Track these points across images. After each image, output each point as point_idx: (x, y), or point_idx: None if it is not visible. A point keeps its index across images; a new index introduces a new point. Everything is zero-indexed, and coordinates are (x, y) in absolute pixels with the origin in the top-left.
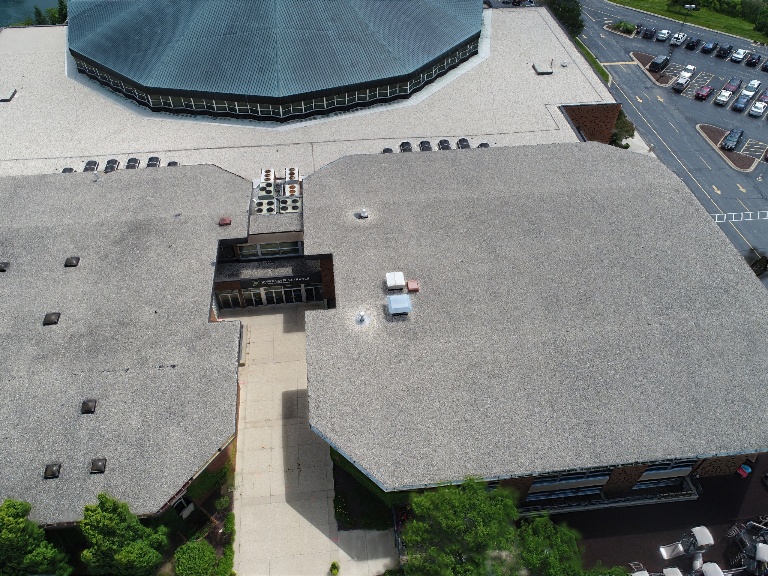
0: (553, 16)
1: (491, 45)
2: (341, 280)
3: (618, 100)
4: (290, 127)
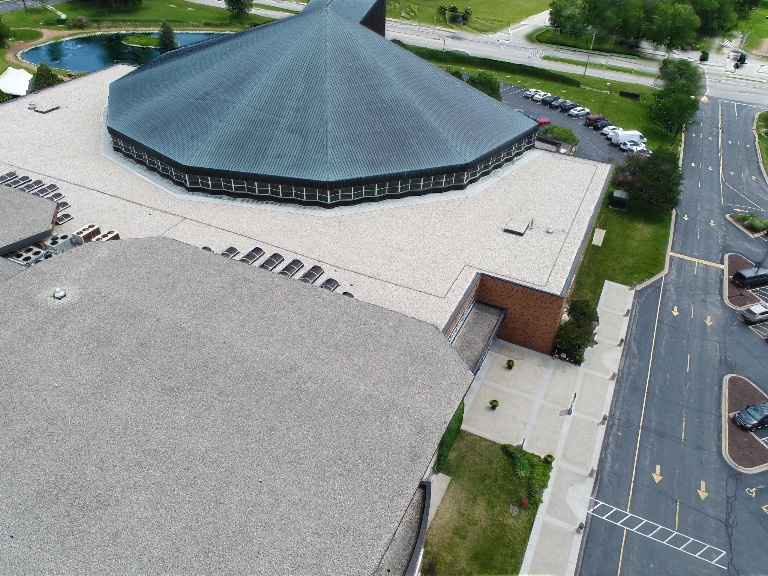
0: (608, 176)
1: (492, 185)
2: None
3: (564, 292)
4: (189, 198)
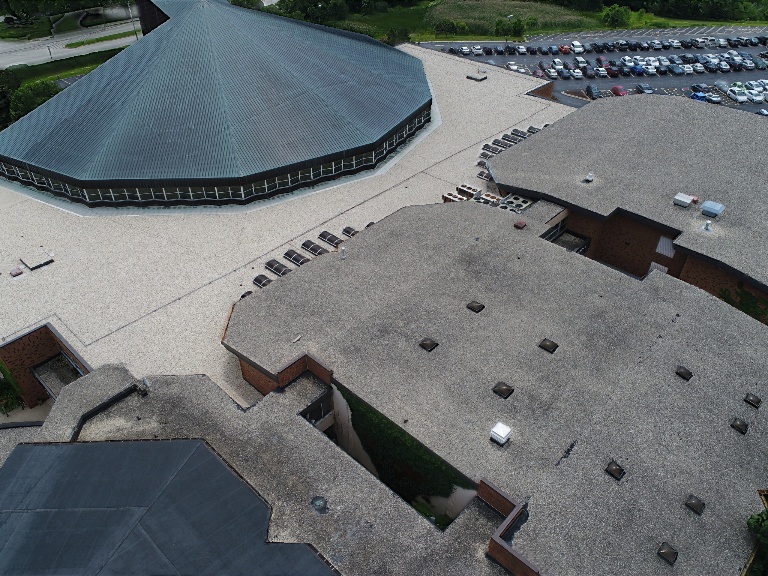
0: (424, 47)
1: None
2: (654, 217)
3: None
4: (385, 169)
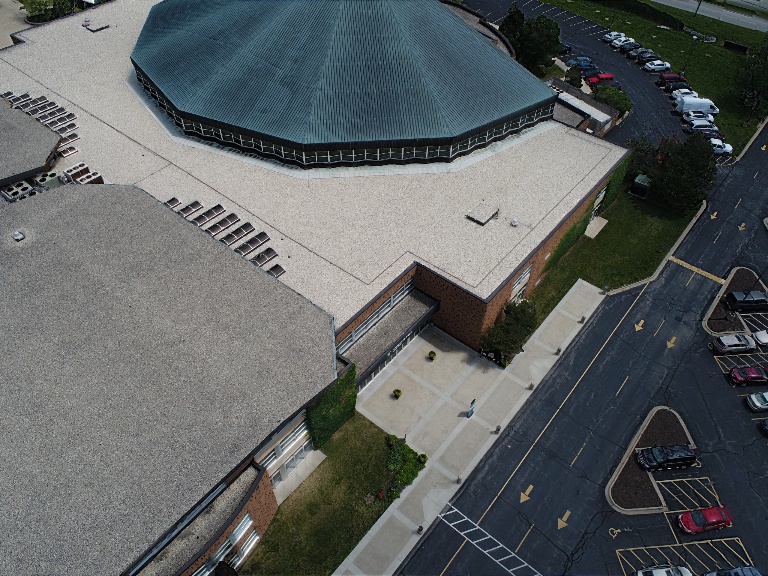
0: (615, 165)
1: (482, 161)
2: None
3: (490, 297)
4: (183, 141)
